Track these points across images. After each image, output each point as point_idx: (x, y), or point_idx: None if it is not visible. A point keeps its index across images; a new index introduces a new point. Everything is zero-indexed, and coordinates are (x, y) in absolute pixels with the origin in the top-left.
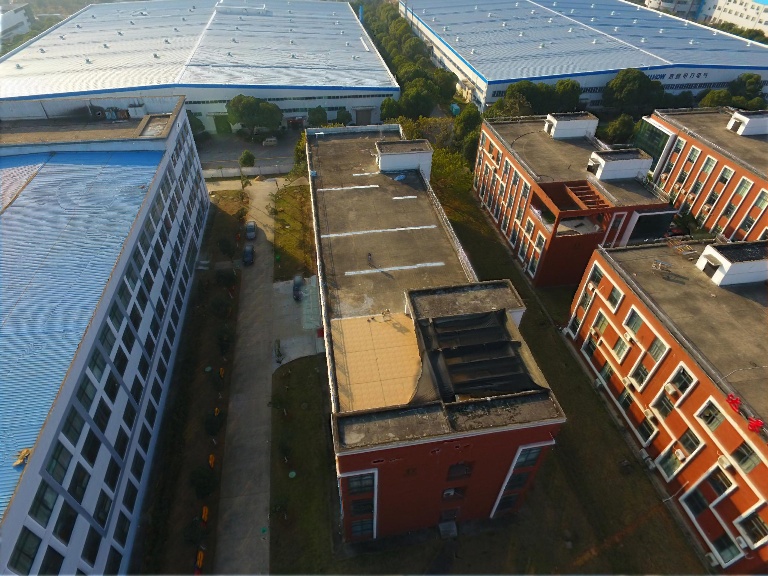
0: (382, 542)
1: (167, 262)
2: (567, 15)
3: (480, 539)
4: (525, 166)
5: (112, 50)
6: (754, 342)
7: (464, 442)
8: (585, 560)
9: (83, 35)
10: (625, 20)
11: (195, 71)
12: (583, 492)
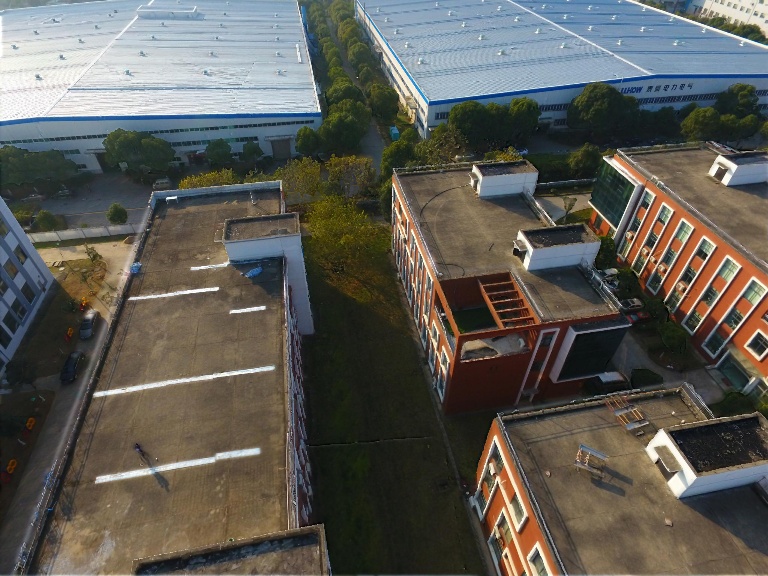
0: None
1: None
2: (537, 12)
3: None
4: (427, 251)
5: None
6: None
7: None
8: None
9: None
10: (603, 16)
11: (75, 97)
12: None
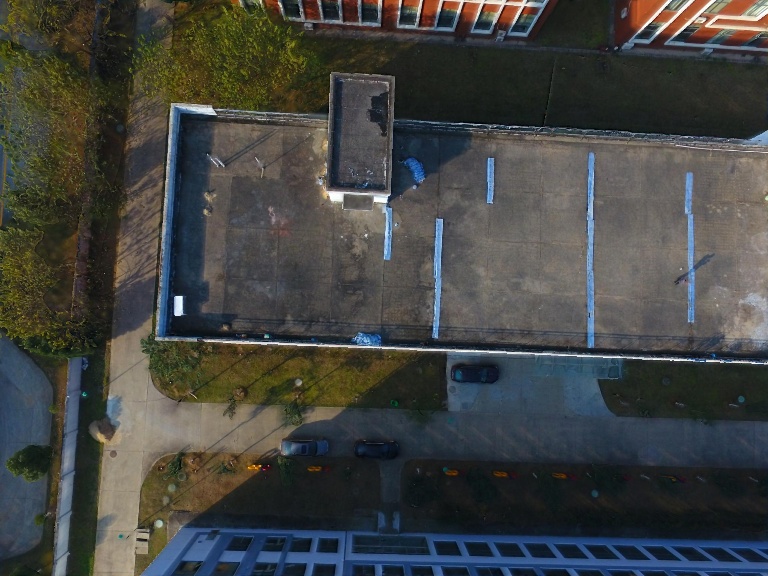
0: None
1: None
2: None
3: None
4: None
5: None
6: None
7: None
8: None
9: None
10: None
11: None
12: None
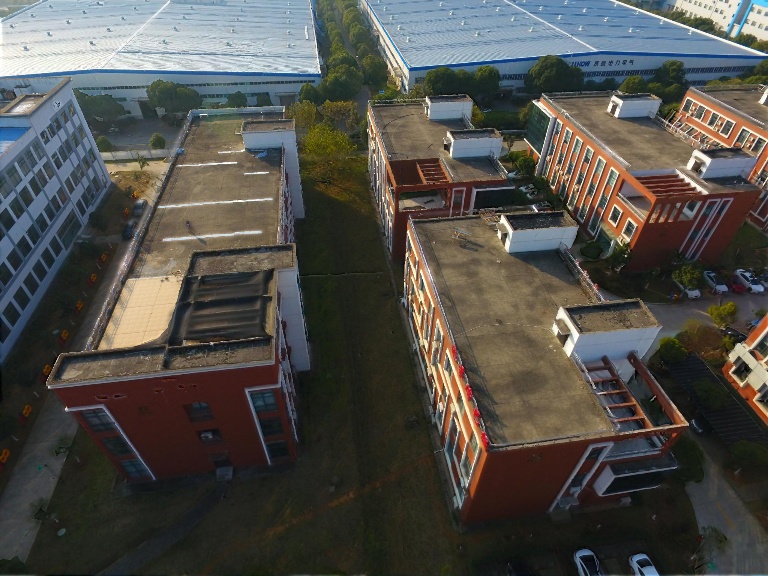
0: (160, 483)
1: (22, 232)
2: (518, 4)
3: (252, 482)
4: (383, 145)
5: (53, 38)
6: (512, 302)
7: (182, 381)
8: (340, 501)
9: (34, 24)
10: (576, 9)
11: (123, 57)
12: (363, 443)
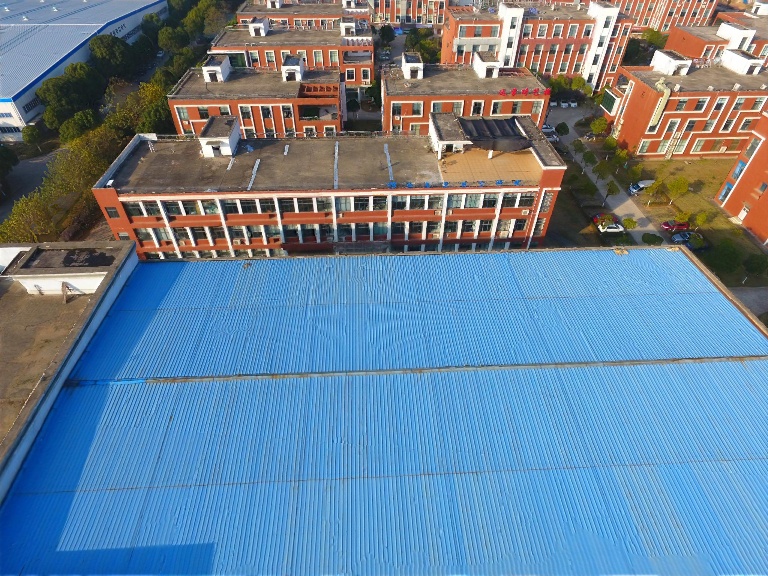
0: None
1: None
2: None
3: None
4: (273, 95)
5: None
6: None
7: None
8: None
9: None
10: None
11: None
12: None
